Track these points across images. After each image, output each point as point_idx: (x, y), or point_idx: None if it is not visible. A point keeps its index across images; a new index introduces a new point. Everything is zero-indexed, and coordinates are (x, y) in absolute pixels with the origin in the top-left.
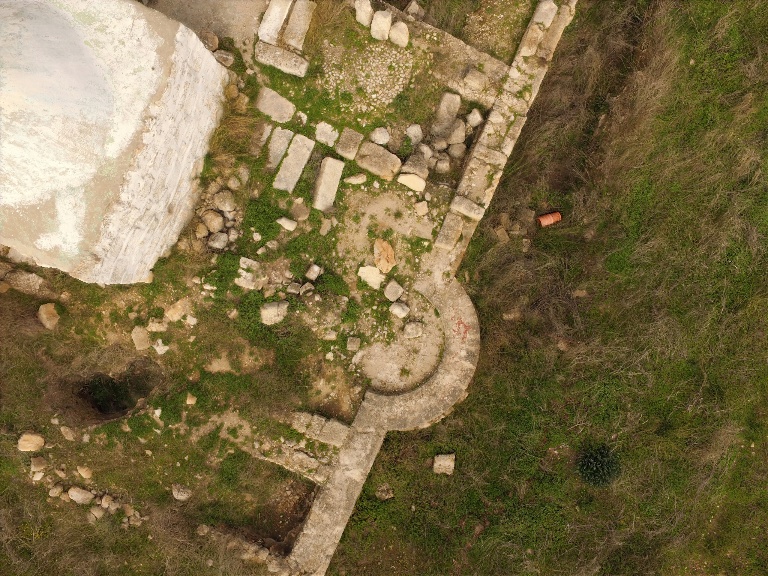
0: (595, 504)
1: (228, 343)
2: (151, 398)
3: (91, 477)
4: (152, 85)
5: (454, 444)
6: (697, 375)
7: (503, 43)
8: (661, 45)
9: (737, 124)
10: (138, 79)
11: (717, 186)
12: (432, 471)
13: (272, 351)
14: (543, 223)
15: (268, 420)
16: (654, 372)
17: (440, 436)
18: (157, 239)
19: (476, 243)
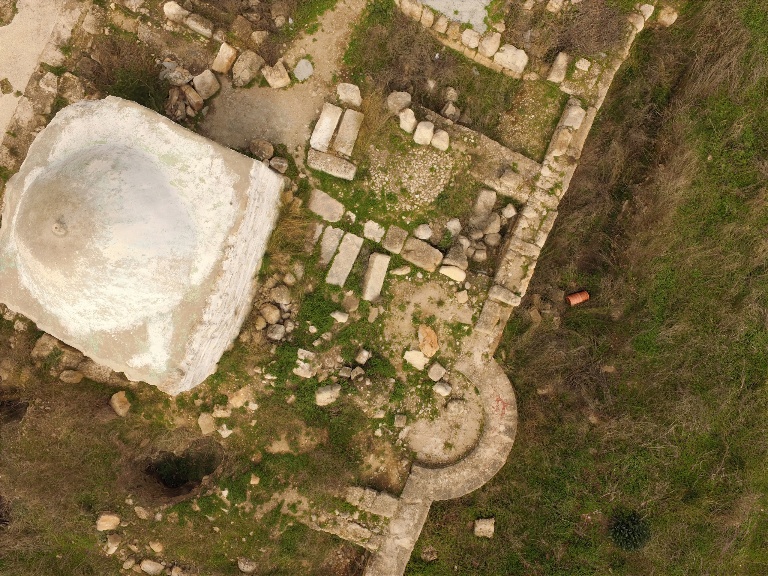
0: (627, 567)
1: (286, 425)
2: (217, 479)
3: (162, 551)
4: (230, 218)
5: (493, 509)
6: (719, 446)
7: (534, 141)
8: (681, 141)
9: (753, 215)
10: (218, 214)
11: (735, 272)
12: (473, 534)
13: (325, 430)
14: (572, 302)
15: (324, 495)
16: (679, 444)
17: (480, 502)
18: (224, 338)
19: (511, 324)
